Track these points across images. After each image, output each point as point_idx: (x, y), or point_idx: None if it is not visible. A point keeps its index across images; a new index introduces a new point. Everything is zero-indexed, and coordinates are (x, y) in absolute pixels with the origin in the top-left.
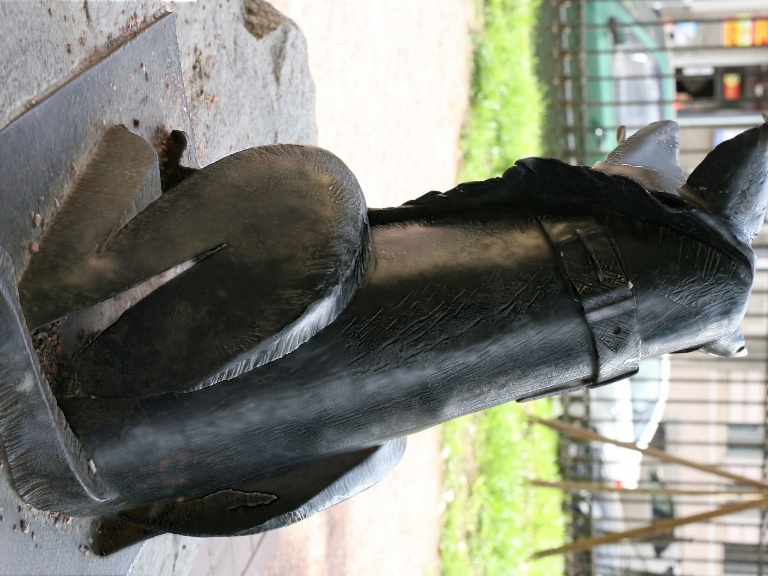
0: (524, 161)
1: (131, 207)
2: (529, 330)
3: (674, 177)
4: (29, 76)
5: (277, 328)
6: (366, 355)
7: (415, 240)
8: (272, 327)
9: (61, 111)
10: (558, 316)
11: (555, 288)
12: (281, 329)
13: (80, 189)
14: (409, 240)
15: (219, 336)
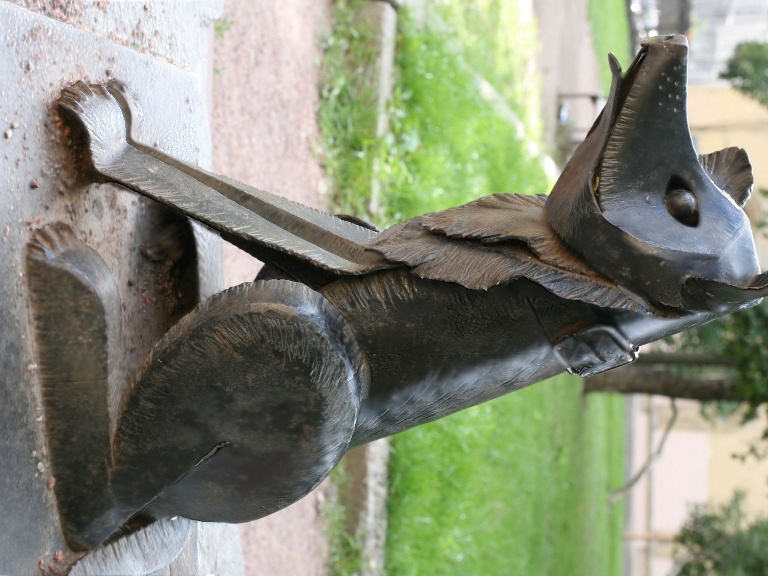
0: None
1: (109, 386)
2: (532, 383)
3: (680, 159)
4: None
5: (304, 492)
6: (382, 430)
7: (404, 335)
8: (299, 492)
9: None
10: (559, 370)
11: (555, 362)
12: (308, 490)
13: (48, 380)
14: (397, 335)
15: (254, 501)
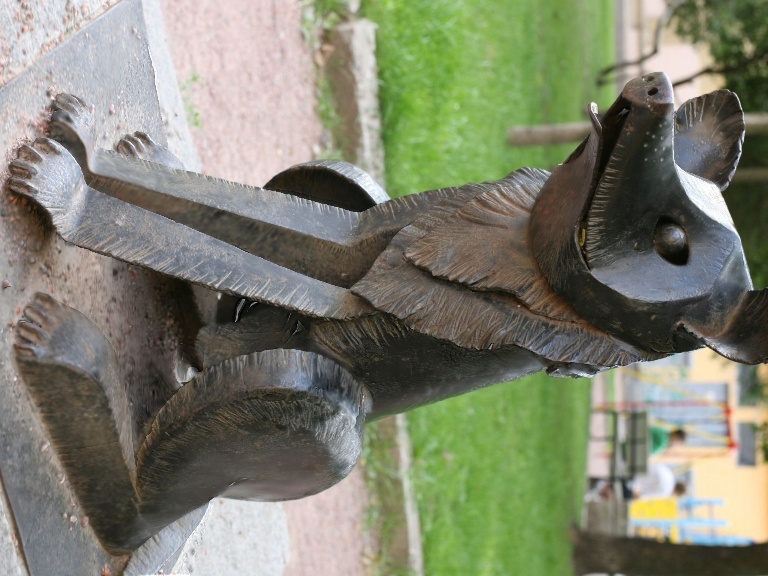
0: (501, 347)
1: (122, 444)
2: None
3: (668, 201)
4: (3, 555)
5: None
6: None
7: (400, 367)
8: None
9: (18, 486)
10: None
11: None
12: None
13: (62, 449)
14: (394, 367)
15: None
